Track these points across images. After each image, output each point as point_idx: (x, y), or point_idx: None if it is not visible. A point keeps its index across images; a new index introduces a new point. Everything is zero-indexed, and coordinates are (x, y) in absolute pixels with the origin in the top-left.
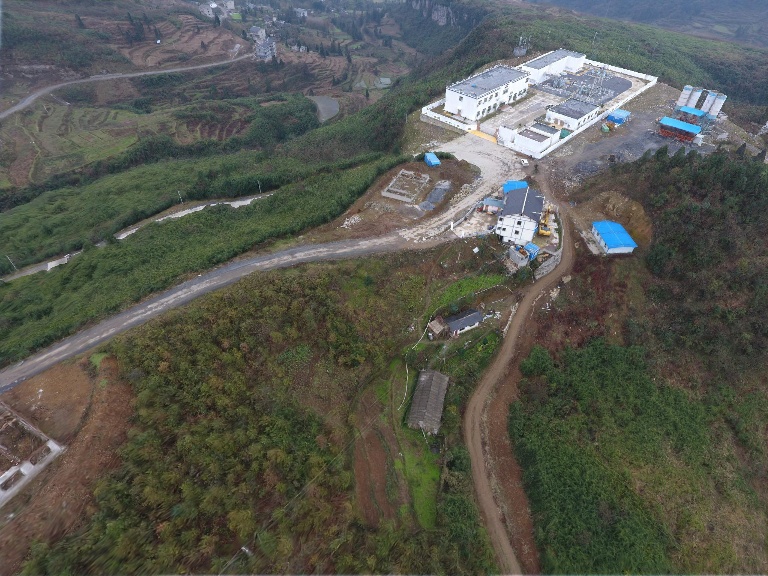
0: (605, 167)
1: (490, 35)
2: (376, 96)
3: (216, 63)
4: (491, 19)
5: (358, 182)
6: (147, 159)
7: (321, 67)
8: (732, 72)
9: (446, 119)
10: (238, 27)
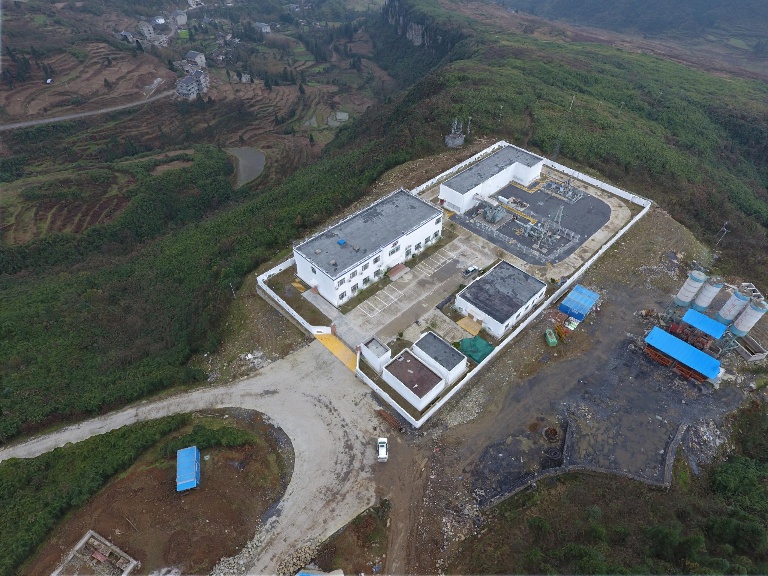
0: (534, 466)
1: (417, 111)
2: (325, 139)
3: (122, 106)
4: (438, 71)
5: None
6: None
7: (263, 103)
8: (756, 129)
9: (286, 307)
10: (169, 54)
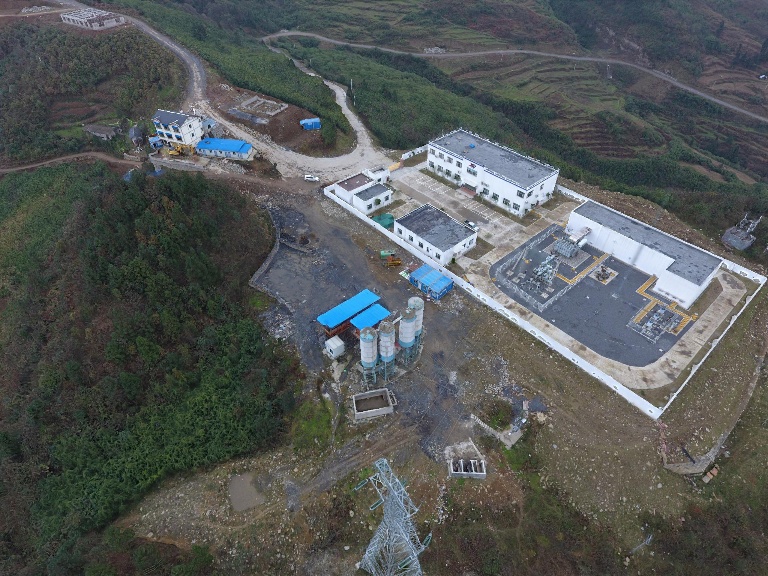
0: None
1: None
2: None
3: None
4: None
5: (273, 89)
6: (516, 114)
7: None
8: None
9: (422, 148)
10: None
